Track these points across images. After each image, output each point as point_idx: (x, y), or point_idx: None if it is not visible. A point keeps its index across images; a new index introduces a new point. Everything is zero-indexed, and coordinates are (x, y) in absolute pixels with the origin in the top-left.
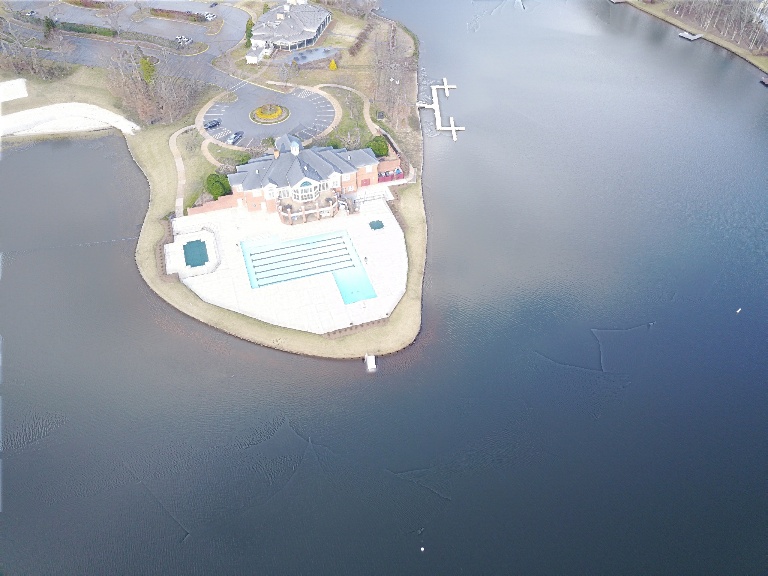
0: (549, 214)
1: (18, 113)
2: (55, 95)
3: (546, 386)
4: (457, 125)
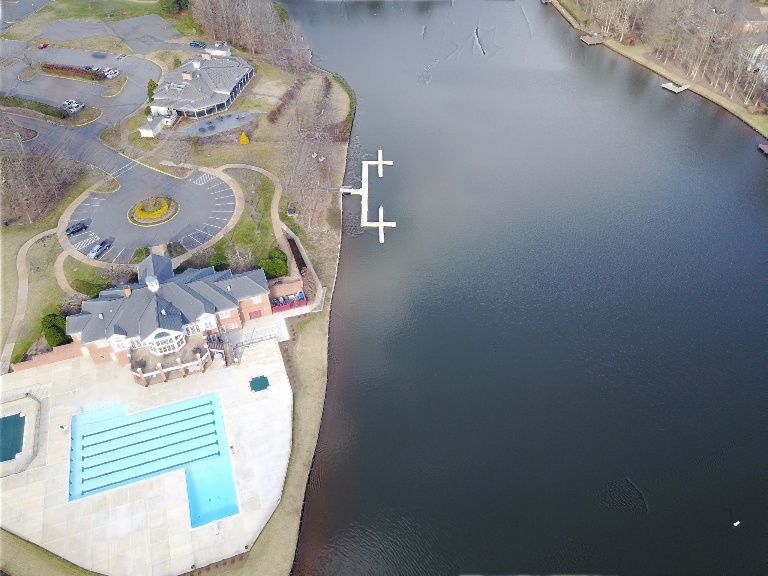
0: None
1: None
2: None
3: None
4: (387, 219)
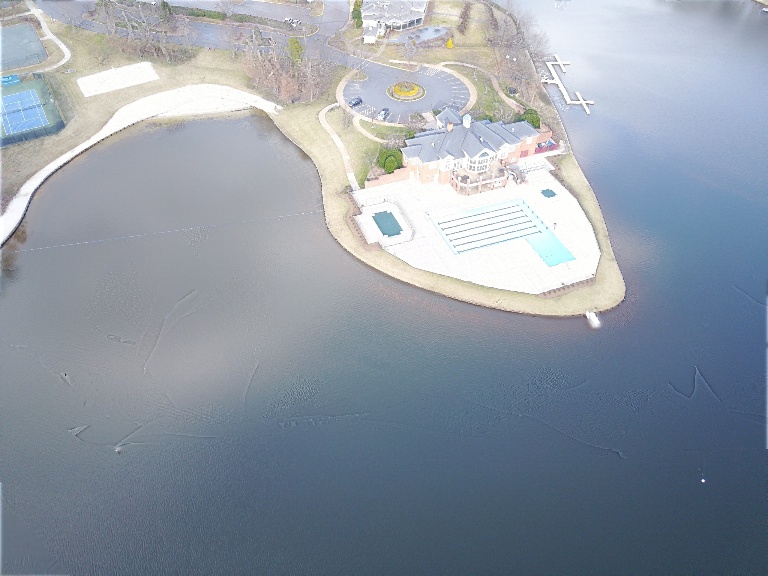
0: None
1: (155, 95)
2: (185, 77)
3: None
4: (585, 99)
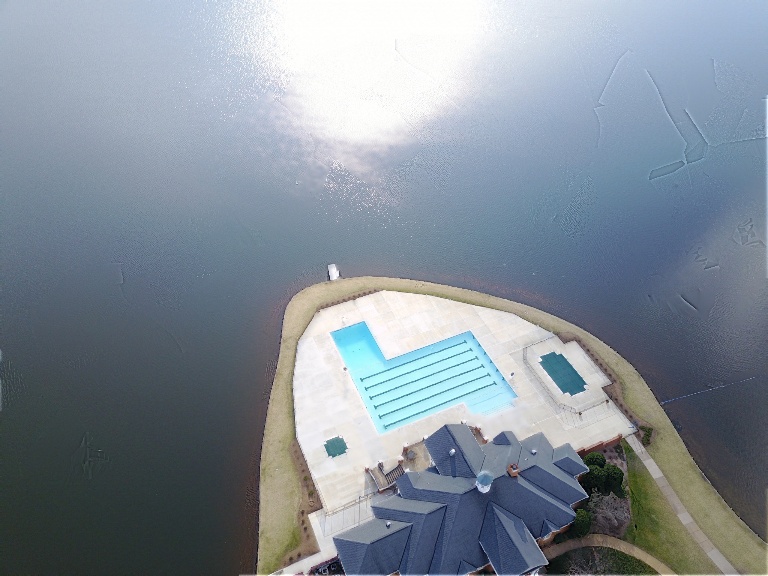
0: (60, 484)
1: None
2: None
3: (192, 203)
4: None
